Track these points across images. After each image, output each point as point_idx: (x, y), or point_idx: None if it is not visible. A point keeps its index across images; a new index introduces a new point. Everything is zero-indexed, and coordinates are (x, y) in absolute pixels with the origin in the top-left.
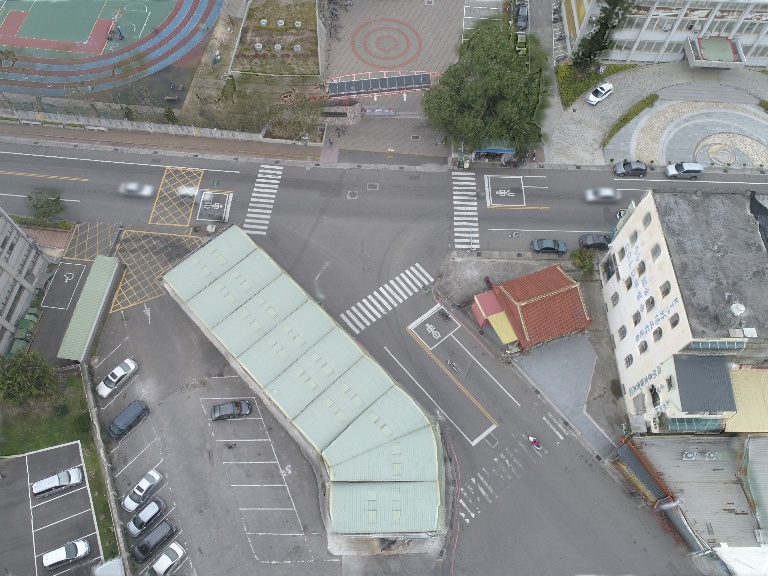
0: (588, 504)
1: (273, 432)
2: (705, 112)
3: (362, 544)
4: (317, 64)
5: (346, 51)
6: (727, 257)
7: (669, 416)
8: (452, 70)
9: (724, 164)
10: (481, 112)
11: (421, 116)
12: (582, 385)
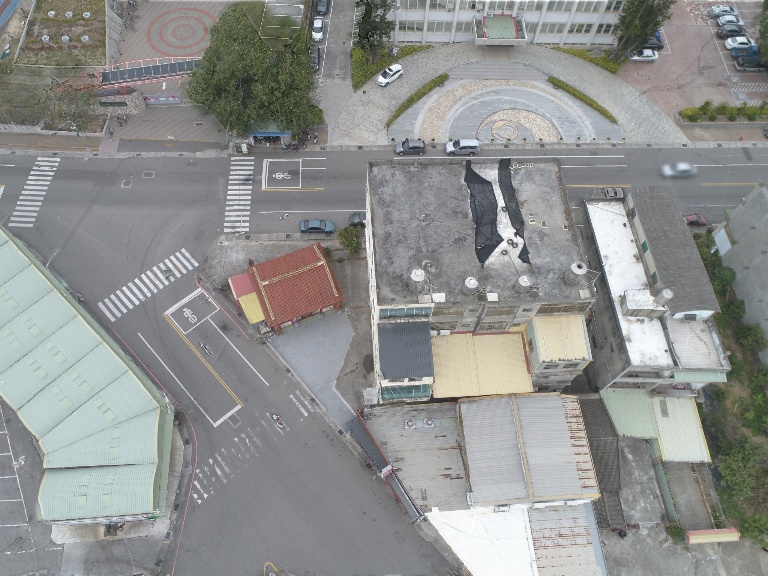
0: (323, 478)
1: (11, 424)
2: (494, 90)
3: (81, 530)
4: (105, 54)
5: (141, 41)
6: (432, 225)
7: (382, 385)
8: None
9: (506, 139)
10: (240, 95)
11: None
12: (335, 362)
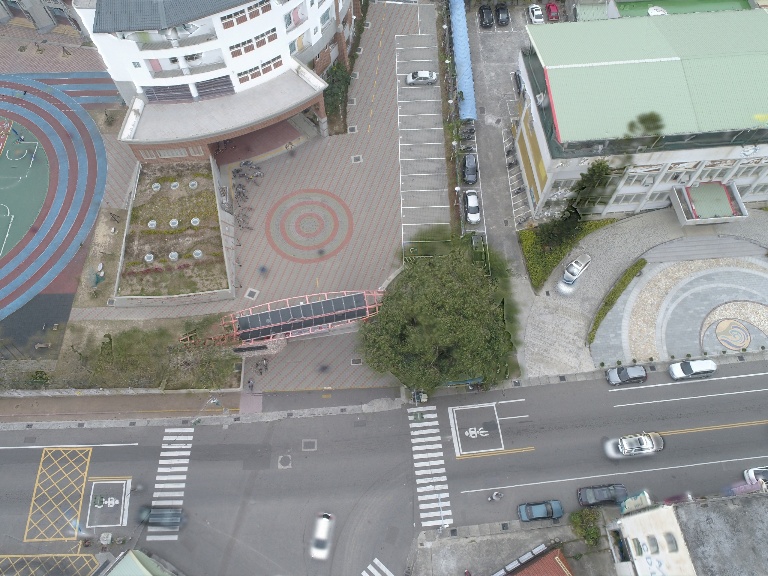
0: None
1: None
2: (704, 274)
3: None
4: (225, 273)
5: (260, 243)
6: None
7: None
8: (389, 314)
9: (738, 348)
10: None
11: None
12: None
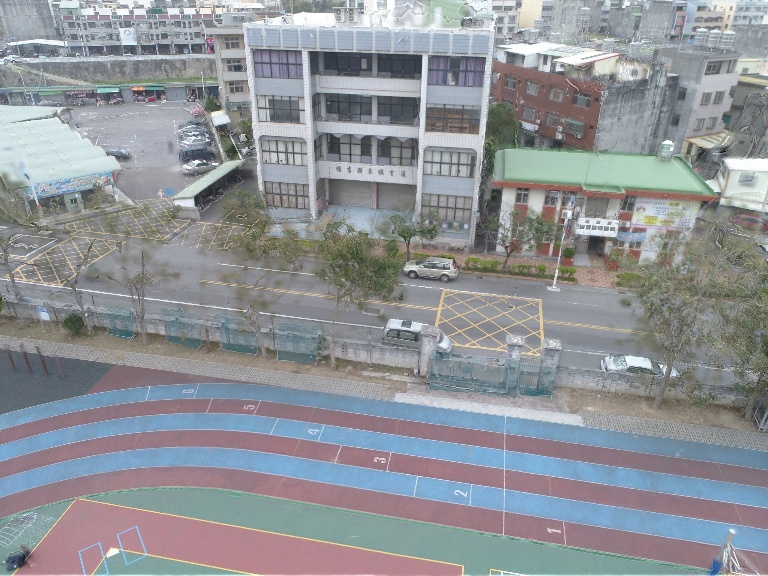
0: None
1: None
2: None
3: None
4: None
5: None
6: None
7: None
8: None
9: None
10: None
11: None
12: None
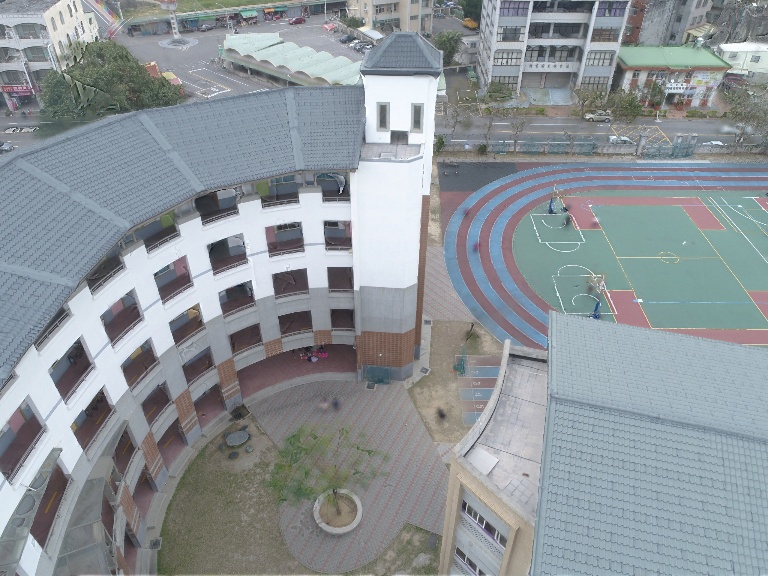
0: None
1: None
2: None
3: None
4: None
5: None
6: None
7: None
8: None
9: None
10: None
11: None
12: None
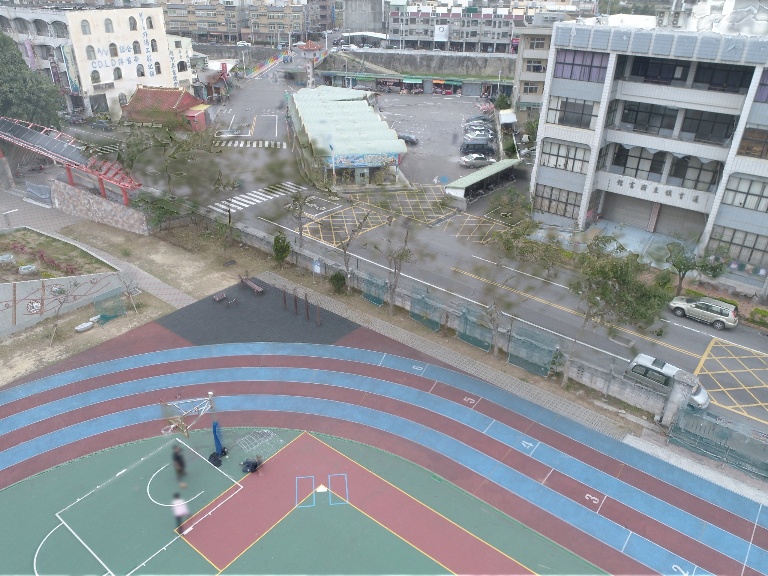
0: None
1: None
2: None
3: None
4: (2, 235)
5: None
6: None
7: None
8: None
9: None
10: None
11: (13, 184)
12: None
